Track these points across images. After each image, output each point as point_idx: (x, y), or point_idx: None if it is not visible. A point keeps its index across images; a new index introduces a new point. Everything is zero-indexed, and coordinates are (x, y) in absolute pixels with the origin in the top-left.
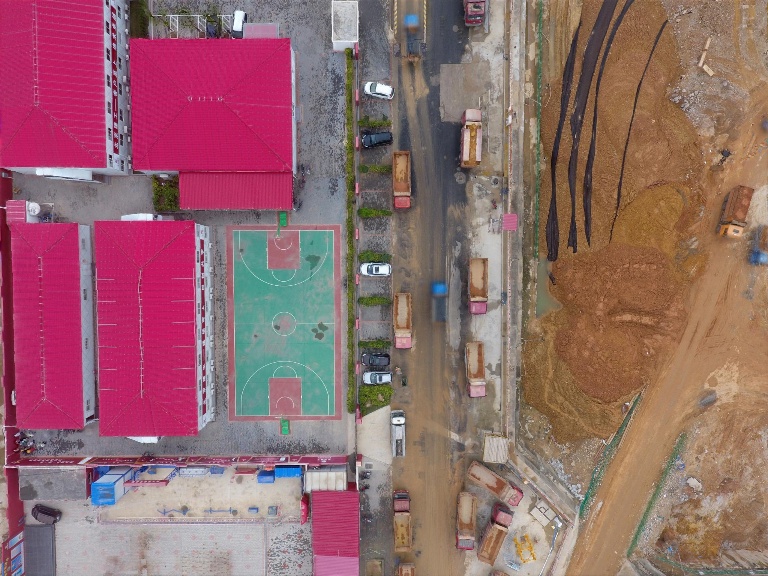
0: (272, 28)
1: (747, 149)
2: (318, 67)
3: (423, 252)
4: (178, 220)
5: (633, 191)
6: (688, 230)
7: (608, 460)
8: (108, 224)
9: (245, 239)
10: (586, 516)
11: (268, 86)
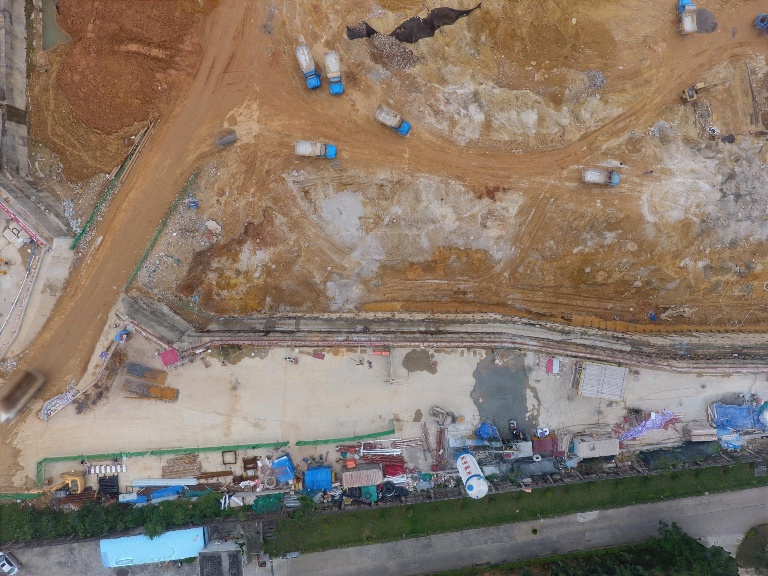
0: None
1: None
2: None
3: None
4: None
5: None
6: None
7: (111, 195)
8: None
9: None
10: (83, 250)
11: None
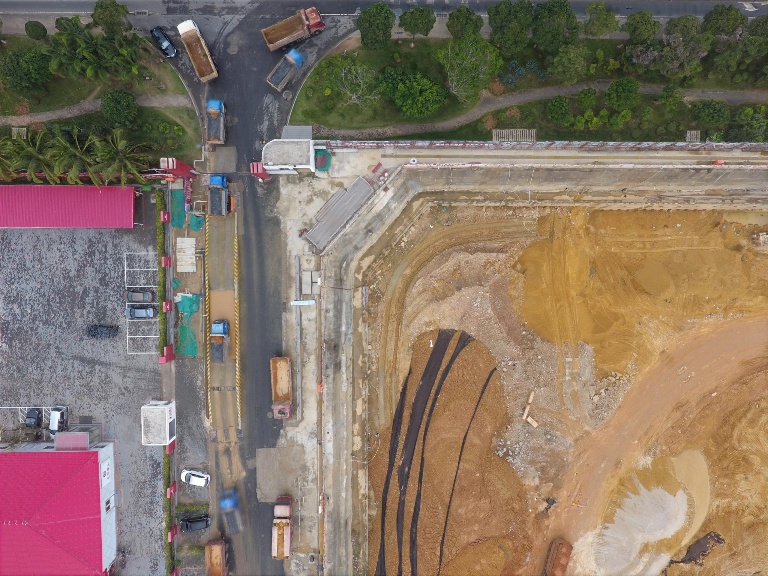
0: (82, 437)
1: (571, 498)
2: (137, 454)
3: None
4: None
5: (455, 548)
6: (515, 575)
7: None
8: None
9: None
10: None
11: (75, 501)
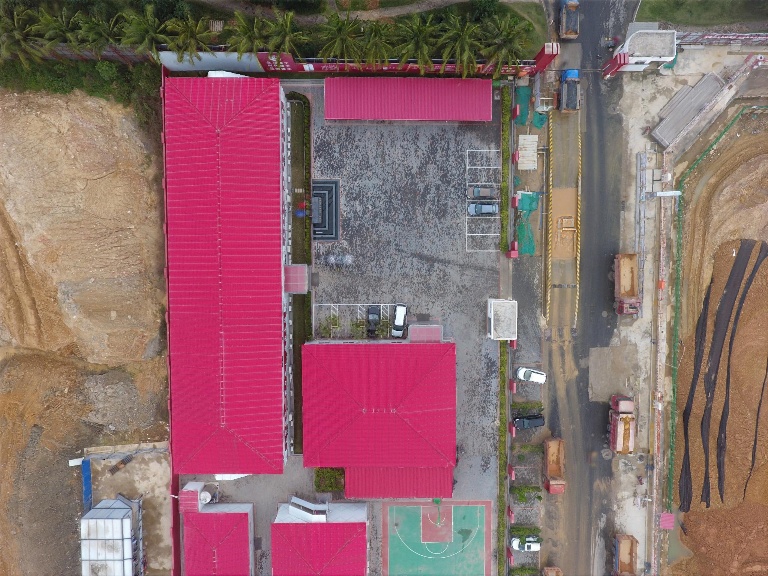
0: (436, 330)
1: None
2: (472, 352)
3: (570, 524)
4: (336, 497)
5: (767, 453)
6: None
7: None
8: (284, 527)
9: (400, 514)
10: None
11: (435, 391)
